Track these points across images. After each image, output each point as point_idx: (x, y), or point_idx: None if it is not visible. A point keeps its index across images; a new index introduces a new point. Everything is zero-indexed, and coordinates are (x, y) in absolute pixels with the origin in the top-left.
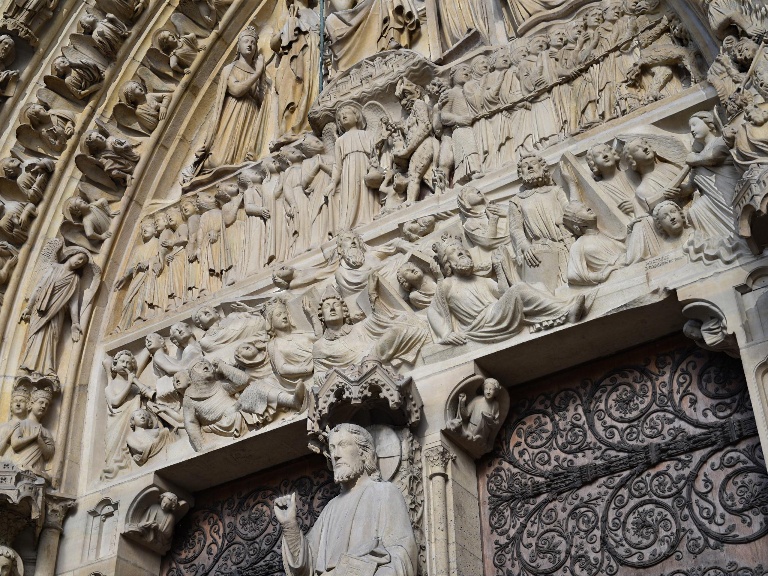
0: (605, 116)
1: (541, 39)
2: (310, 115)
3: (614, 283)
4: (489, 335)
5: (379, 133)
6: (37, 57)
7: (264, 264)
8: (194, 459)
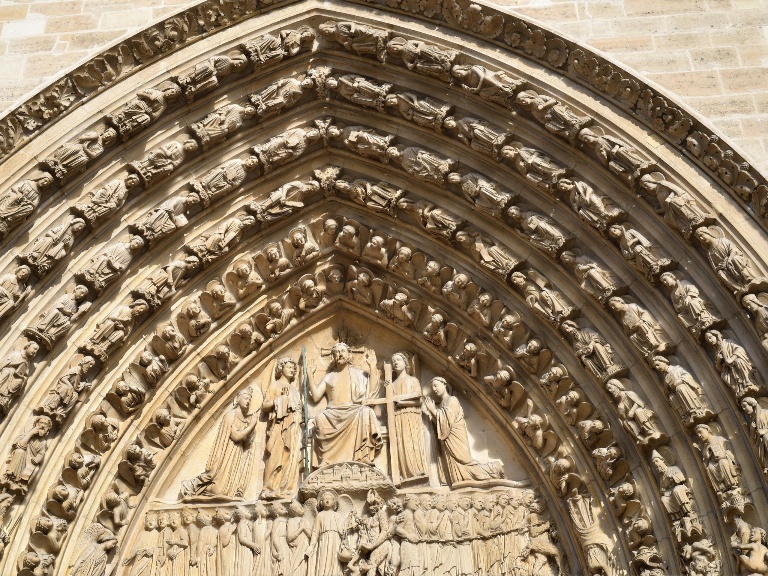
0: (505, 575)
1: (469, 500)
2: (302, 489)
3: None
4: None
5: (349, 520)
6: (103, 373)
7: None
8: None
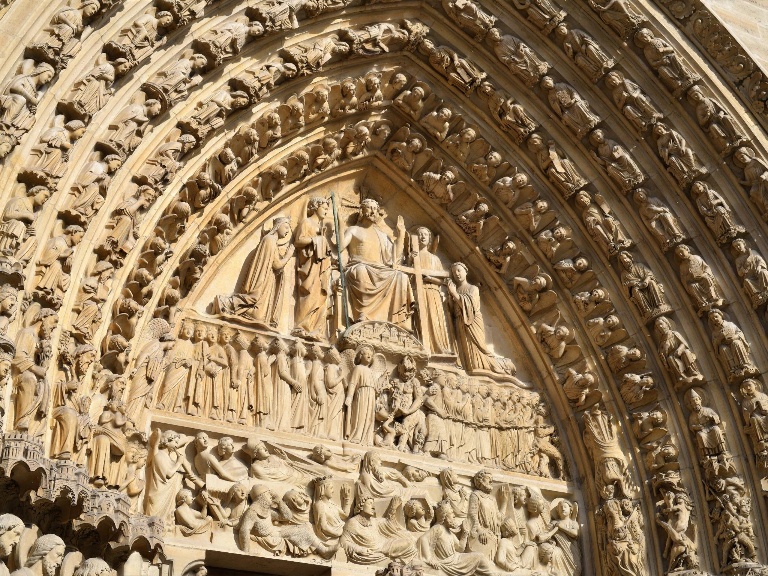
0: None
1: None
2: (347, 338)
3: (517, 575)
4: (454, 572)
5: (383, 380)
6: (189, 157)
7: (293, 426)
8: (239, 555)
